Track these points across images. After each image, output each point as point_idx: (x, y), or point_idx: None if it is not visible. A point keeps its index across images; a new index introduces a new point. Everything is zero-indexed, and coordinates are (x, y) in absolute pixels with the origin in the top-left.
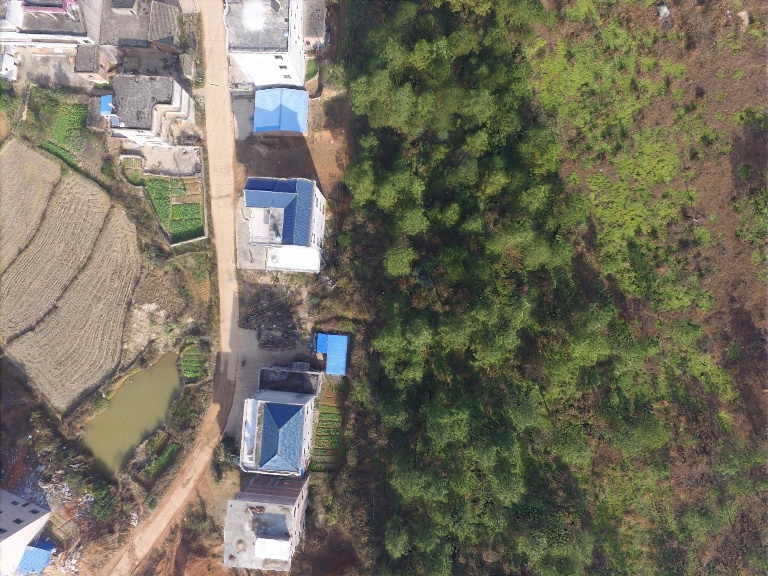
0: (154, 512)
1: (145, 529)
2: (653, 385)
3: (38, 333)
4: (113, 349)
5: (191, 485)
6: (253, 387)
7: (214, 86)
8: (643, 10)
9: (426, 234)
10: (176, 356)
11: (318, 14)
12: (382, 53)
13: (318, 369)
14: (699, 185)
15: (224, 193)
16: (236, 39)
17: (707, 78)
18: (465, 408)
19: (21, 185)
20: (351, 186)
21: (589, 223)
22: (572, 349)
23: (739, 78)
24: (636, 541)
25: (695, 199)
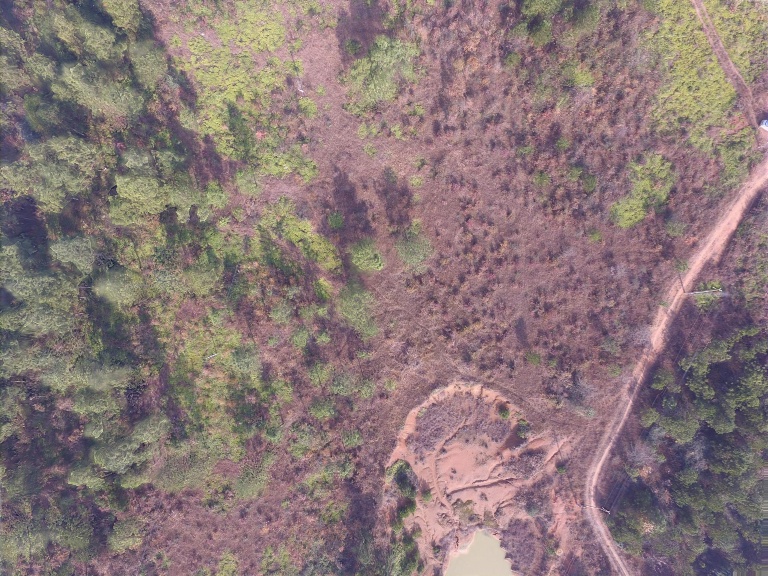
0: None
1: None
2: (245, 246)
3: None
4: None
5: None
6: None
7: None
8: None
9: None
10: None
11: None
12: None
13: None
14: (305, 56)
15: None
16: None
17: None
18: (15, 245)
19: None
20: None
21: (190, 86)
22: (119, 189)
23: None
24: (213, 395)
25: (302, 70)
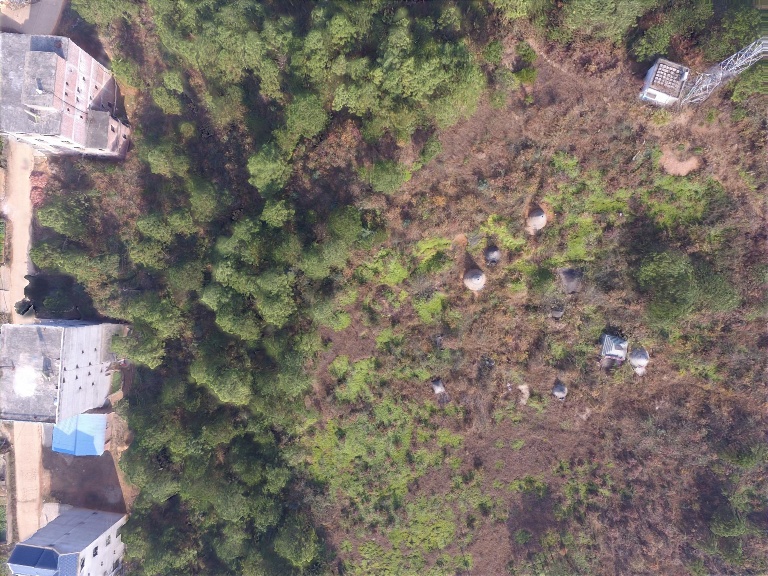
0: None
1: None
2: None
3: None
4: None
5: None
6: None
7: None
8: (419, 385)
9: None
10: None
11: None
12: (141, 443)
13: None
14: (475, 551)
15: (30, 498)
16: (7, 404)
17: (486, 448)
18: None
19: None
20: None
21: None
22: None
23: (519, 448)
24: None
25: (471, 563)
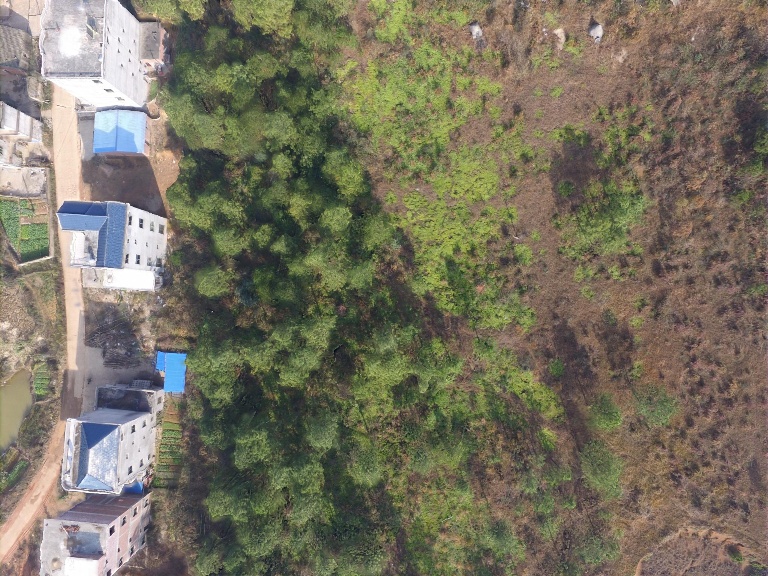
0: (3, 528)
1: None
2: (471, 403)
3: None
4: None
5: (39, 501)
6: None
7: (61, 107)
8: (457, 29)
9: (250, 254)
10: (29, 374)
11: (154, 36)
12: (186, 77)
13: (160, 386)
14: (519, 203)
15: None
16: (53, 64)
17: (525, 96)
18: (265, 428)
19: None
20: (173, 207)
21: (407, 242)
22: (367, 370)
23: (557, 95)
24: (451, 559)
25: (516, 217)
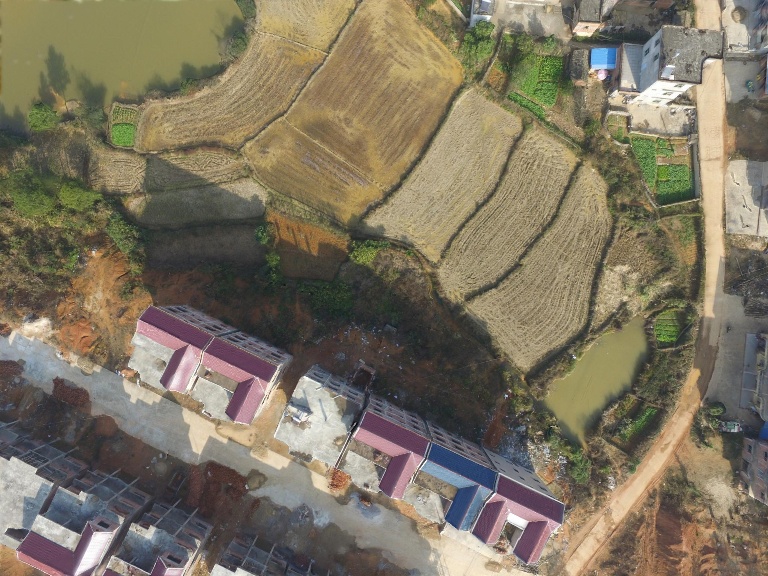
0: (632, 476)
1: (622, 493)
2: None
3: (501, 291)
4: (580, 310)
5: (670, 450)
6: (737, 353)
7: None
8: None
9: None
10: (644, 320)
11: None
12: None
13: None
14: None
15: (713, 156)
16: None
17: None
18: None
19: (479, 137)
20: None
21: None
22: None
23: None
24: None
25: None
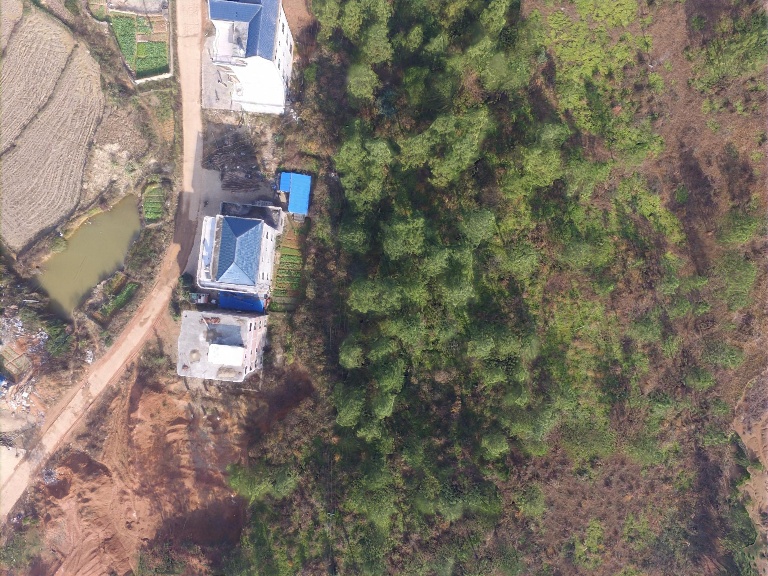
0: (110, 350)
1: (100, 367)
2: (604, 220)
3: None
4: (72, 190)
5: (149, 324)
6: None
7: None
8: None
9: (391, 67)
10: (137, 199)
11: None
12: None
13: None
14: (655, 31)
15: (191, 33)
16: None
17: None
18: None
19: None
20: (318, 12)
21: (549, 60)
22: (526, 162)
23: None
24: (582, 366)
25: (651, 45)
